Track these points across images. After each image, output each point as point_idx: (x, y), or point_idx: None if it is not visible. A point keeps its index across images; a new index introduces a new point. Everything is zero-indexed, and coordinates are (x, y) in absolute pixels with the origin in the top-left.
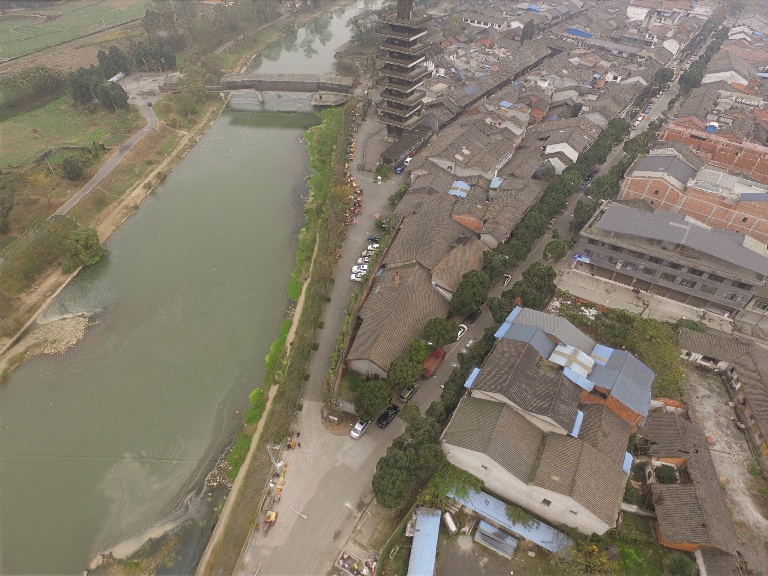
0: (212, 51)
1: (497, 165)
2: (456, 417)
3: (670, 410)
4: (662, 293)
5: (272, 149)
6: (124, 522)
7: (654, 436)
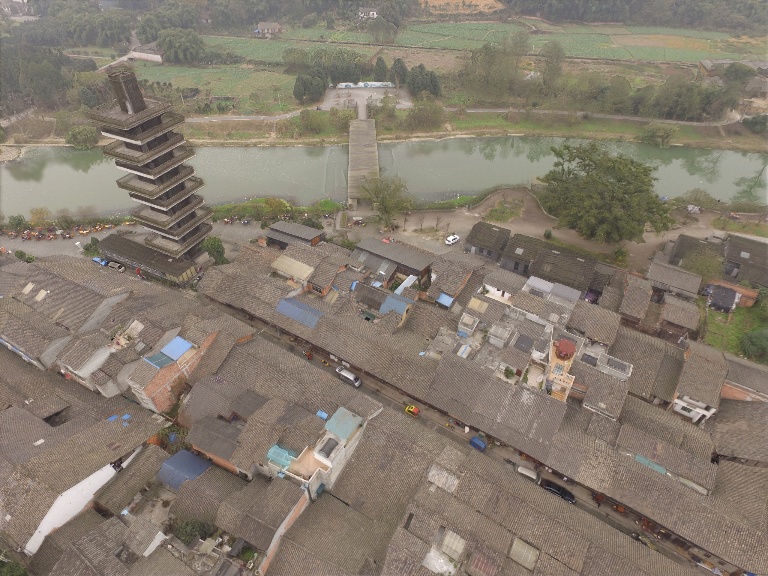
0: (498, 107)
1: None
2: None
3: None
4: None
5: (231, 184)
6: None
7: None
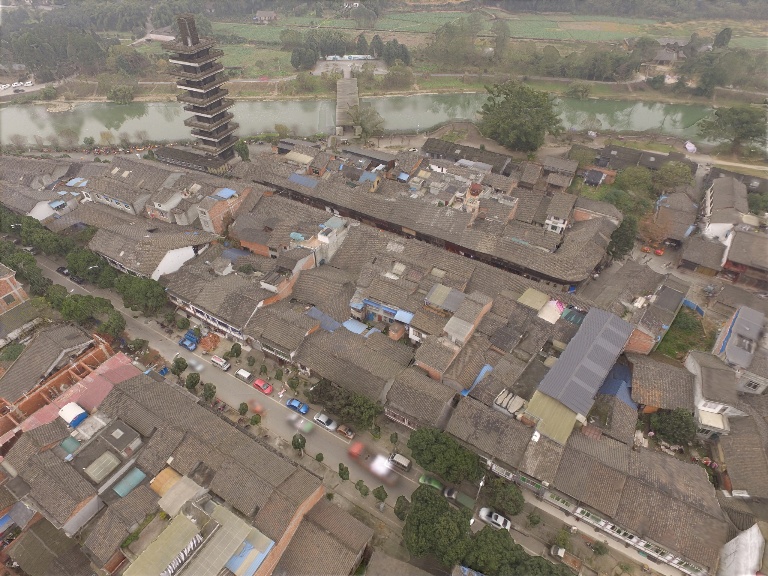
0: (456, 73)
1: None
2: None
3: None
4: None
5: (245, 125)
6: None
7: None
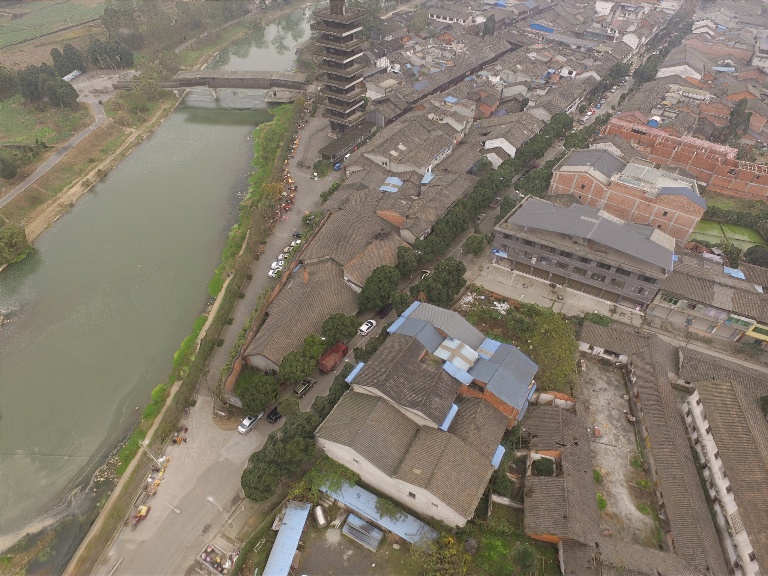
0: (174, 48)
1: (432, 161)
2: (334, 411)
3: (561, 403)
4: (577, 287)
5: (218, 146)
6: (5, 518)
7: (536, 429)
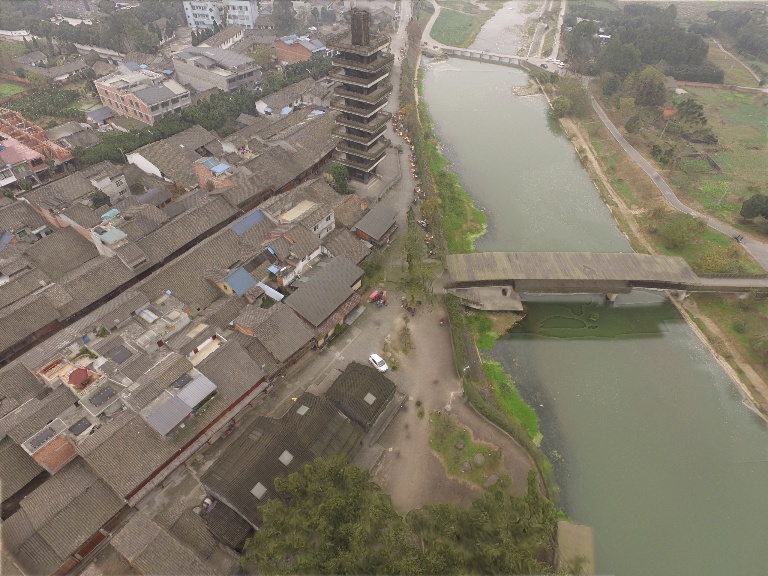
0: None
1: None
2: None
3: None
4: None
5: (509, 196)
6: None
7: None
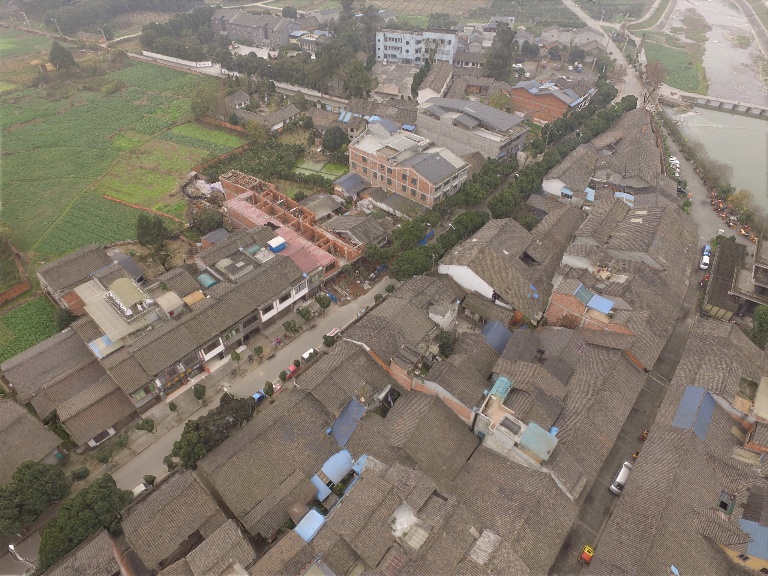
0: None
1: None
2: None
3: None
4: None
5: None
6: None
7: None
